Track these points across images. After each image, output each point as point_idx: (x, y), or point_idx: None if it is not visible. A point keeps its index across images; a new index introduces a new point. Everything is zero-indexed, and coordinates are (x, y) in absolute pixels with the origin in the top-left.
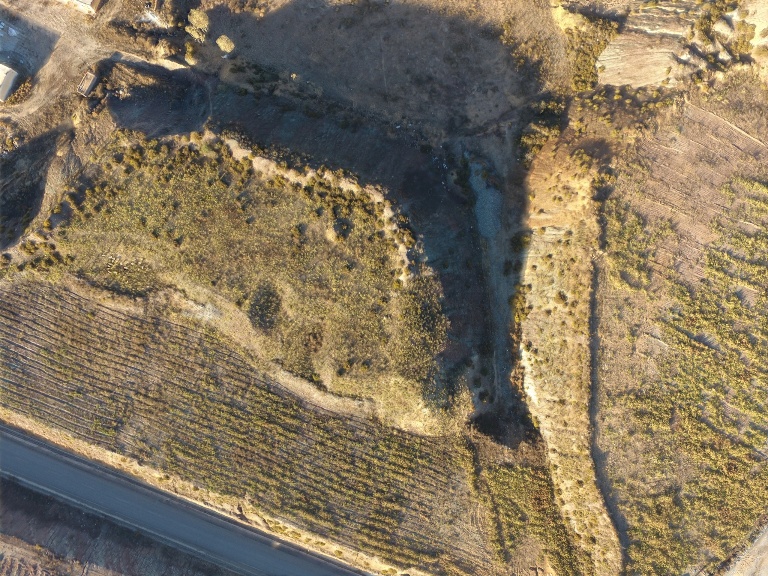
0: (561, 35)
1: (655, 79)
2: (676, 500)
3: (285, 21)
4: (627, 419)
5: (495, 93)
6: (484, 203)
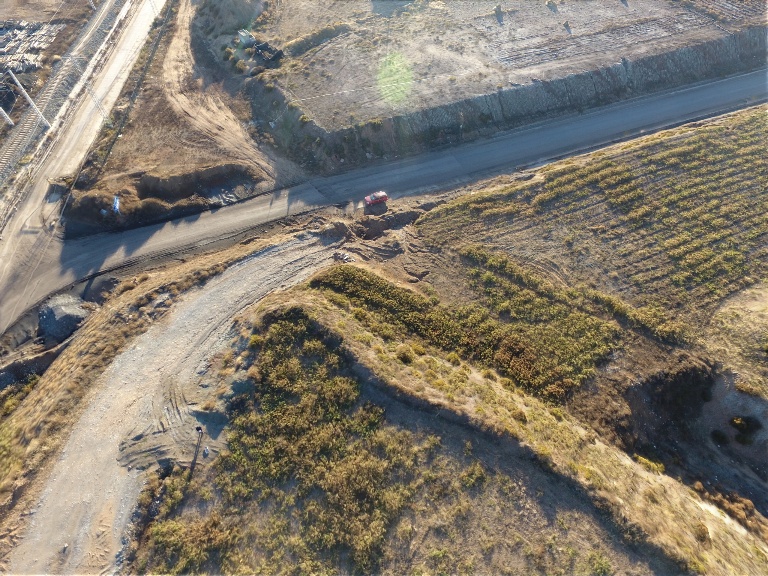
0: None
1: None
2: (344, 557)
3: None
4: None
5: None
6: None
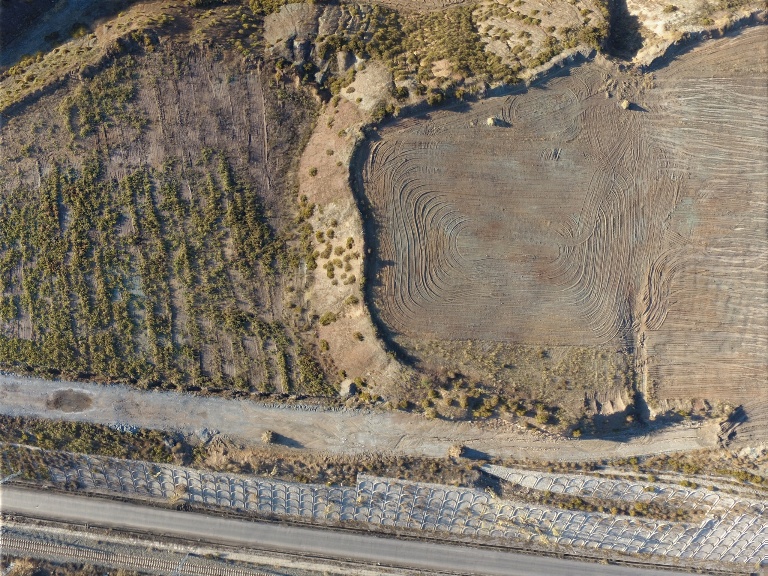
0: None
1: (271, 39)
2: None
3: None
4: None
5: None
6: None
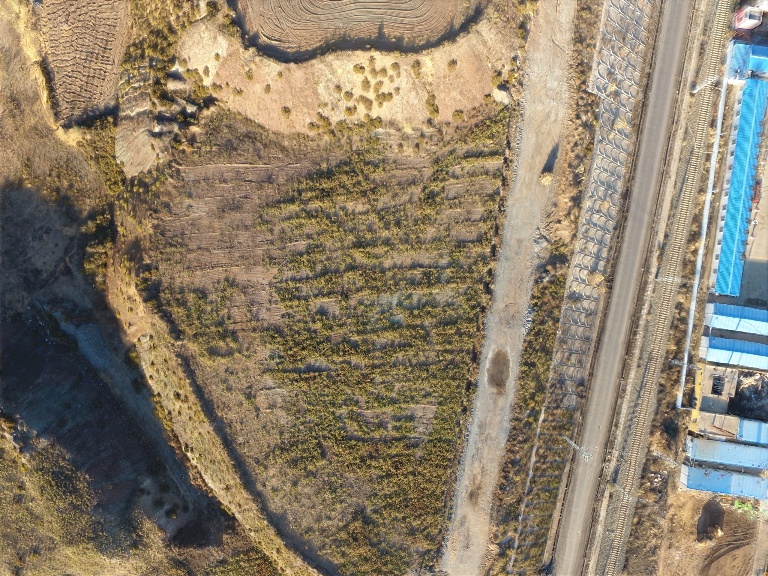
0: (76, 151)
1: (151, 159)
2: (367, 519)
3: None
4: (285, 474)
5: (50, 234)
6: (81, 343)
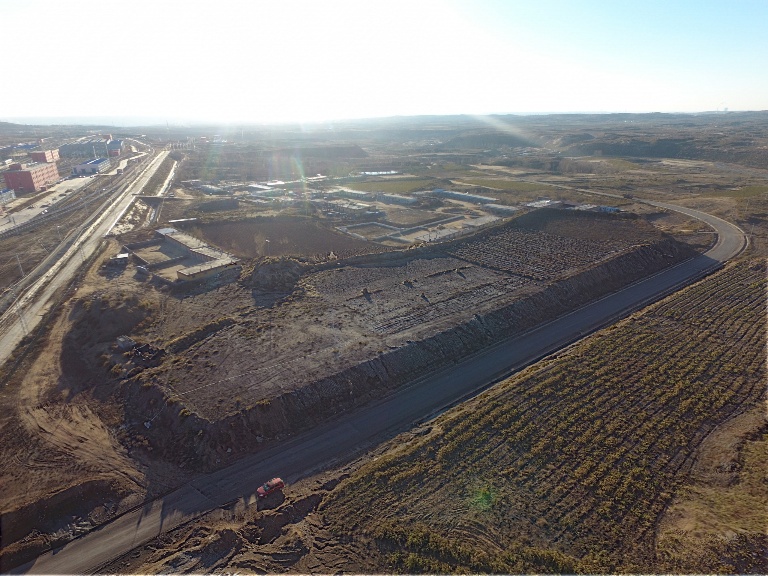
0: None
1: None
2: None
3: None
4: None
5: None
6: None
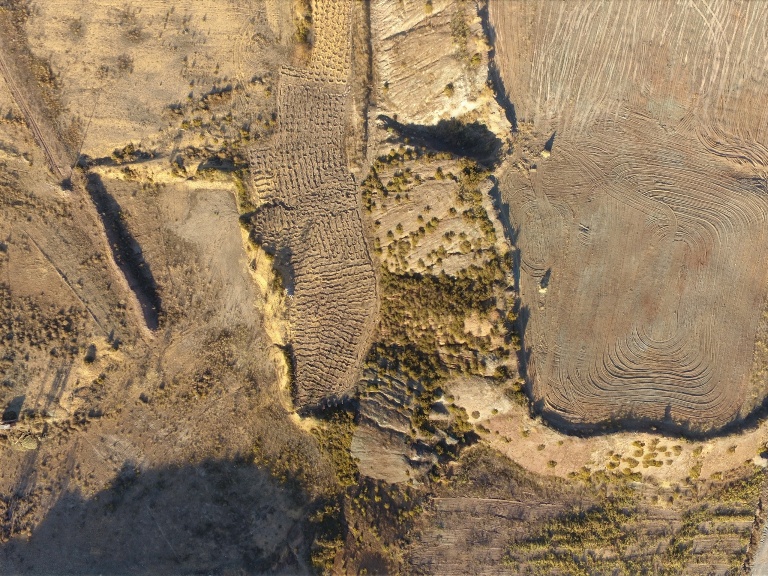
0: (309, 436)
1: (401, 479)
2: None
3: (54, 529)
4: None
5: (273, 514)
6: None
